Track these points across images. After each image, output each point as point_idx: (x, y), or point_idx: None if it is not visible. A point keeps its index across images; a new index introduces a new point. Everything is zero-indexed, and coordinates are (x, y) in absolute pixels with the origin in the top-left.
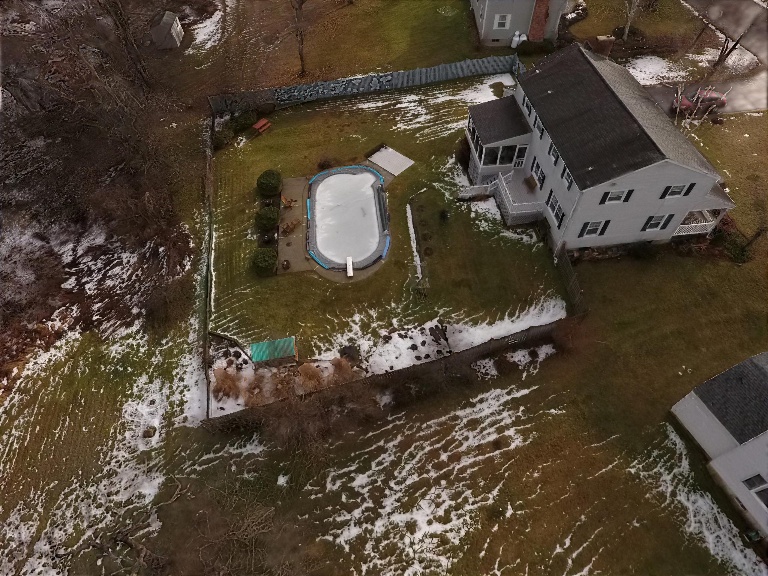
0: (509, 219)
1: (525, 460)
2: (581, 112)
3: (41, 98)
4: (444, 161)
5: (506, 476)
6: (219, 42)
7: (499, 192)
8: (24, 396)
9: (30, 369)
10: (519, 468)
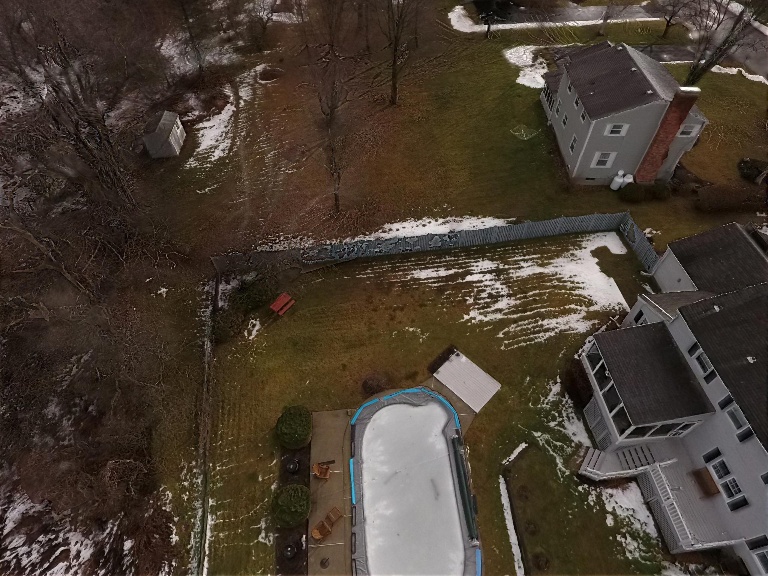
0: (677, 549)
1: None
2: None
3: None
4: (545, 388)
5: None
6: (229, 152)
7: (651, 486)
8: None
9: None
10: None
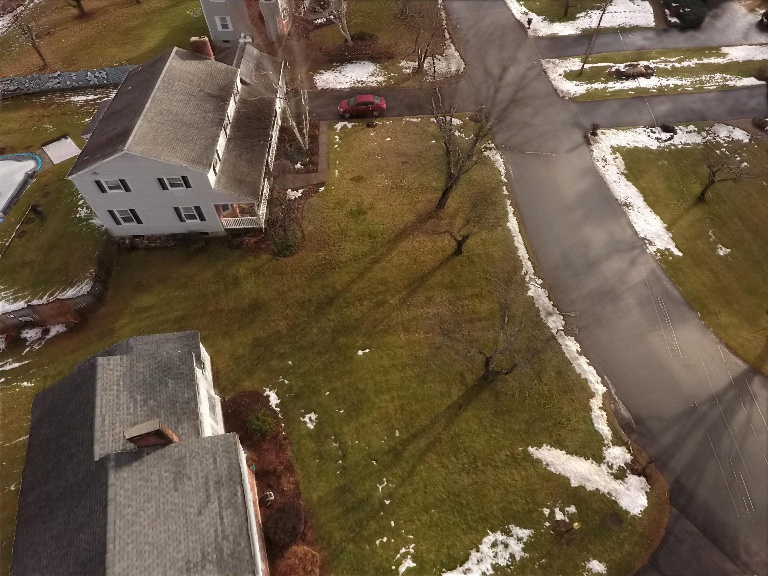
0: None
1: None
2: (126, 106)
3: None
4: None
5: None
6: (0, 35)
7: None
8: None
9: None
10: None
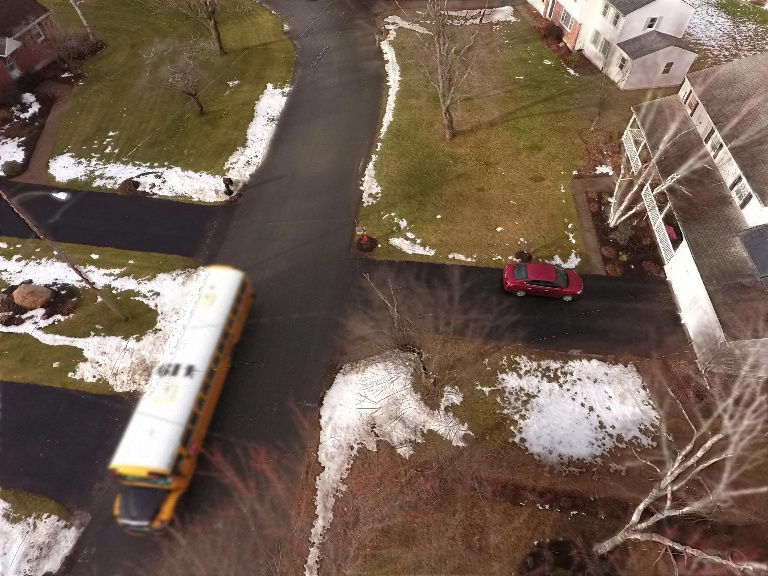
0: None
1: None
2: None
3: None
4: None
5: None
6: None
7: None
8: None
9: None
10: None
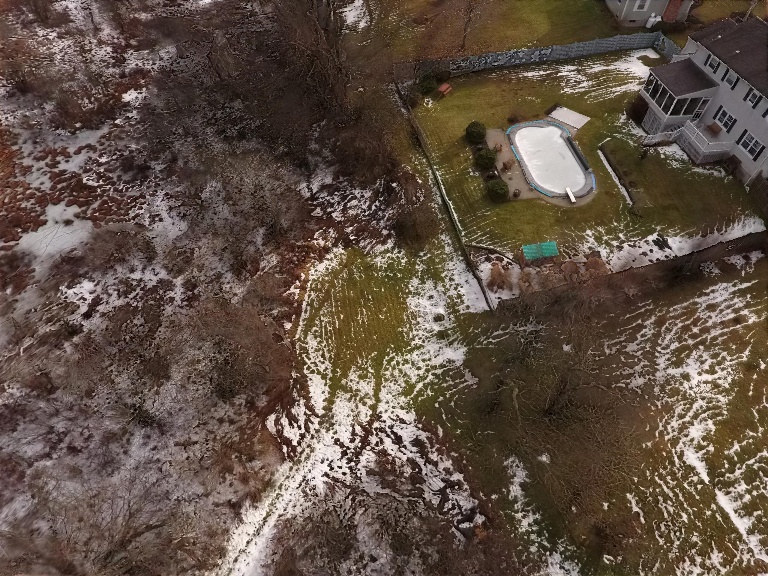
0: (700, 157)
1: (764, 331)
2: None
3: (228, 68)
4: (617, 117)
5: (752, 342)
6: (371, 23)
7: (685, 137)
8: (319, 294)
9: (314, 275)
10: (761, 336)
